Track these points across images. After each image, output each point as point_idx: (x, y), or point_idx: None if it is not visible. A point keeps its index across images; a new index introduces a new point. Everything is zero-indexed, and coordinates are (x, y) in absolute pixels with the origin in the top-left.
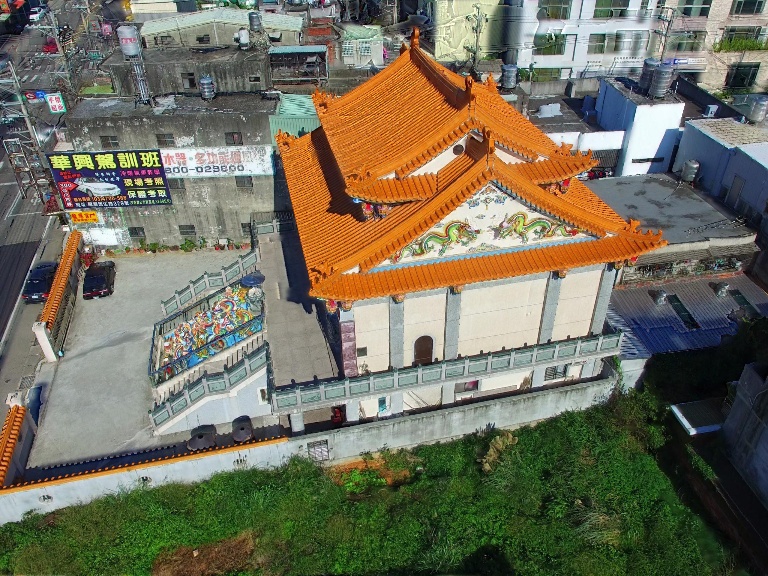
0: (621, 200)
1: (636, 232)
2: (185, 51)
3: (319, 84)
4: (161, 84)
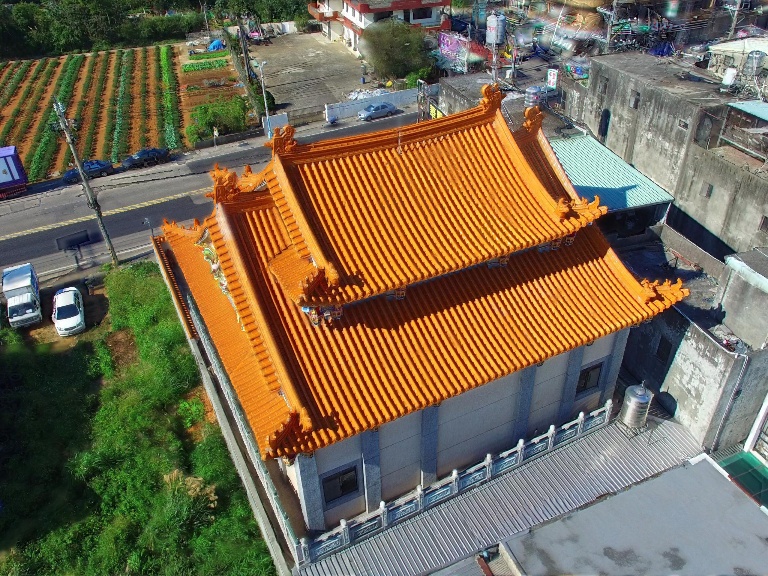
0: (692, 542)
1: (307, 432)
2: (673, 71)
3: (762, 166)
4: (616, 93)
